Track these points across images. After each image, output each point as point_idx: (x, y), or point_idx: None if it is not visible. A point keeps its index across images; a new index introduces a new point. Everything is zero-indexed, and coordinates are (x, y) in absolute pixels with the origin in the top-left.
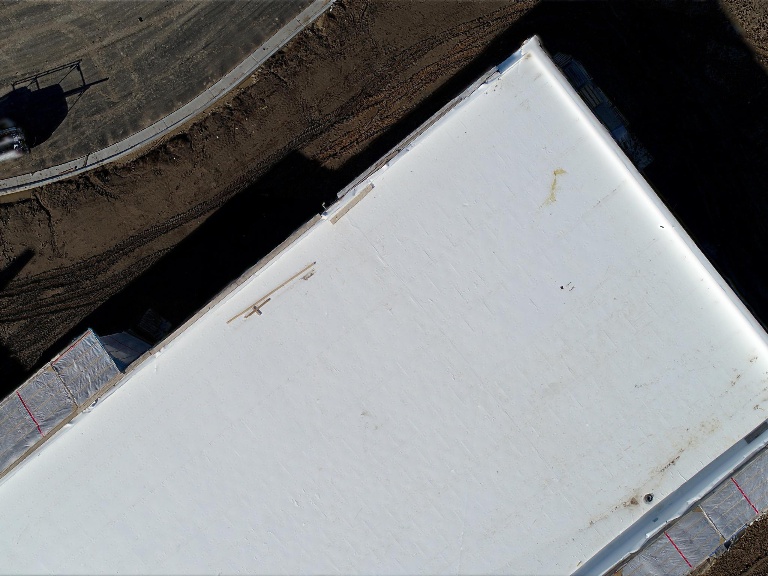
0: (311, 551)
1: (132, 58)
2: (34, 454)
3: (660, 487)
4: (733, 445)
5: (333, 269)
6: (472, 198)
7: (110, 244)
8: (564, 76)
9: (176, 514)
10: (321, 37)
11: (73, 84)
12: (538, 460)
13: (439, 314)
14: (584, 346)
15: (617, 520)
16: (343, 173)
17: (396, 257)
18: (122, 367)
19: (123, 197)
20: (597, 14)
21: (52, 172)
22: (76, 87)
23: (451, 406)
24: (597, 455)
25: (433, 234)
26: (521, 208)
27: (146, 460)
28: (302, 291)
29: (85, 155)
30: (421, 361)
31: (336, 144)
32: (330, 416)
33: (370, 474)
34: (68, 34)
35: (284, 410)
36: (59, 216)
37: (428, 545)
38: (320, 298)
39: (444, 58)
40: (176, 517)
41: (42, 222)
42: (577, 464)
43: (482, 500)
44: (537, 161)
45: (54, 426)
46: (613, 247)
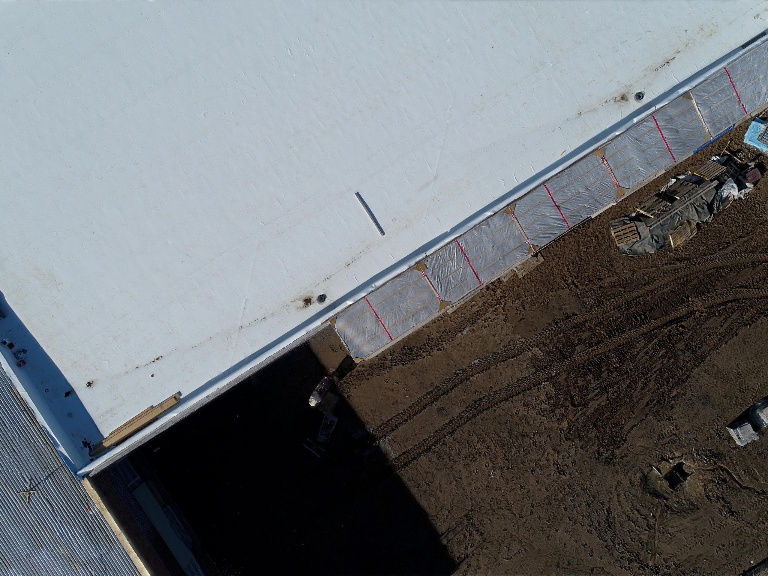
0: (298, 103)
1: None
2: None
3: (652, 86)
4: (729, 52)
5: None
6: None
7: None
8: None
9: (169, 46)
10: None
11: None
12: (534, 41)
13: None
14: None
15: (606, 114)
16: None
17: None
18: None
19: None
20: None
21: None
22: None
23: None
24: (593, 45)
25: None
26: None
27: None
28: None
29: None
30: None
31: None
32: None
33: (366, 32)
34: None
35: None
36: None
37: (415, 113)
38: None
39: None
40: (169, 49)
41: None
42: (572, 51)
43: (474, 74)
44: None
45: None
46: None
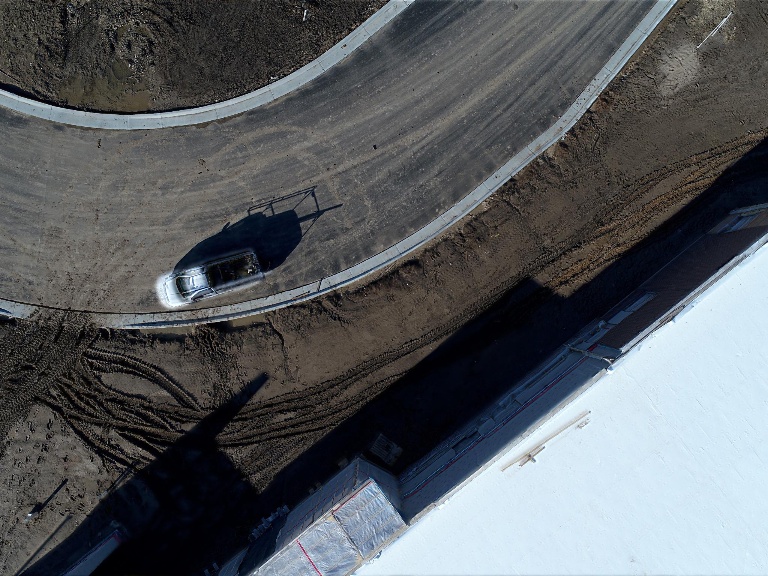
0: None
1: (366, 185)
2: None
3: None
4: None
5: (607, 418)
6: (745, 348)
7: (343, 369)
8: None
9: None
10: (553, 166)
11: (307, 210)
12: None
13: (710, 462)
14: None
15: None
16: (574, 300)
17: (669, 406)
18: (407, 519)
19: (356, 322)
20: None
21: (285, 296)
22: (310, 213)
23: (720, 554)
24: None
25: (706, 384)
26: None
27: None
28: (576, 439)
29: (318, 280)
30: (691, 509)
31: (568, 272)
32: (600, 563)
33: None
34: (303, 161)
35: (555, 557)
36: (293, 341)
37: None
38: (594, 446)
39: (676, 188)
40: None
41: (276, 346)
42: None
43: None
44: None
45: None
46: None
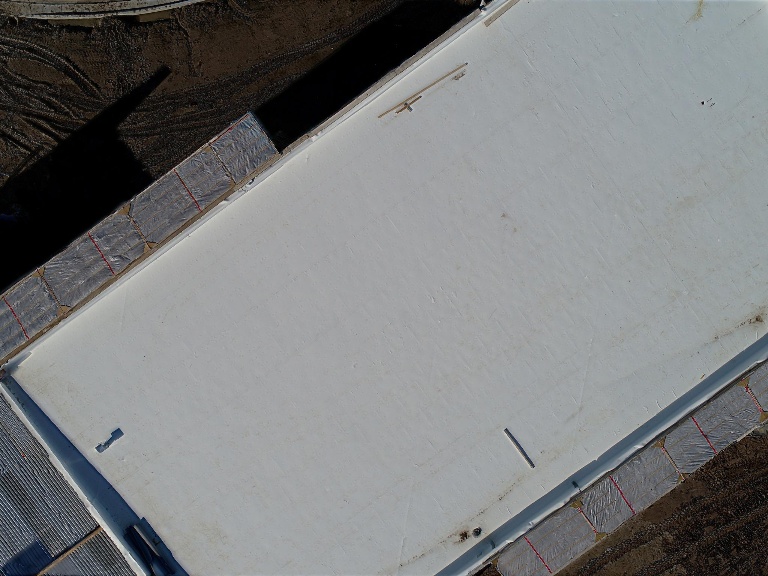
0: (444, 348)
1: None
2: (190, 228)
3: None
4: None
5: (484, 71)
6: (622, 9)
7: (245, 66)
8: None
9: (317, 303)
10: None
11: None
12: (669, 272)
13: (583, 122)
14: (721, 162)
15: (742, 336)
16: (475, 8)
17: (545, 63)
18: (280, 148)
19: (260, 21)
20: None
21: None
22: None
23: (589, 213)
24: (726, 271)
25: (582, 42)
26: (668, 22)
27: (292, 248)
28: (452, 91)
29: None
30: (562, 167)
31: None
32: (471, 216)
33: (506, 276)
34: None
35: (427, 207)
36: (197, 36)
37: (558, 349)
38: (469, 99)
39: None
40: (317, 306)
41: (180, 41)
42: (707, 278)
43: (613, 308)
44: None
45: (212, 201)
46: (755, 66)
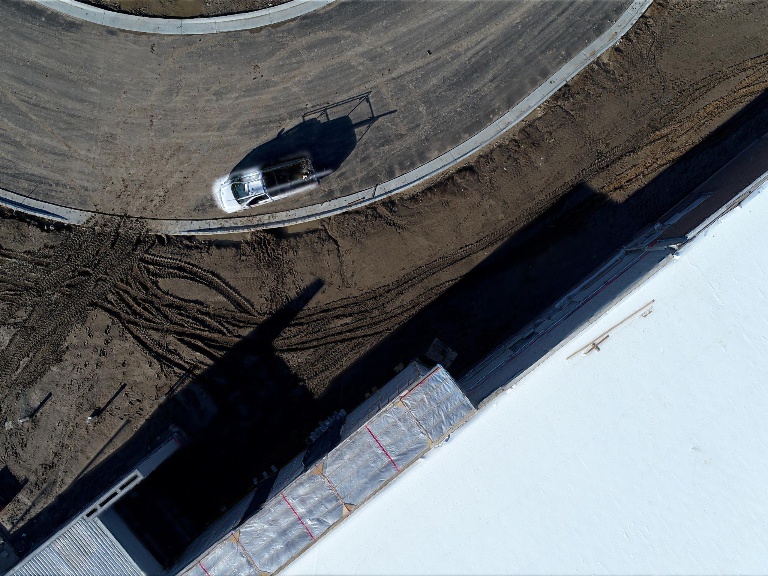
0: None
1: (420, 90)
2: (387, 488)
3: None
4: None
5: (670, 307)
6: None
7: (398, 274)
8: None
9: (509, 545)
10: (608, 71)
11: (362, 116)
12: None
13: None
14: None
15: None
16: (628, 206)
17: (732, 295)
18: (475, 403)
19: (411, 228)
20: None
21: (341, 203)
22: (365, 119)
23: None
24: None
25: None
26: None
27: (483, 493)
28: (640, 328)
29: (373, 186)
30: (751, 397)
31: (622, 177)
32: (661, 450)
33: (698, 507)
34: (358, 66)
35: (617, 444)
36: (348, 246)
37: None
38: (657, 335)
39: (730, 93)
40: (509, 548)
41: (331, 252)
42: None
43: None
44: None
45: (409, 461)
46: None
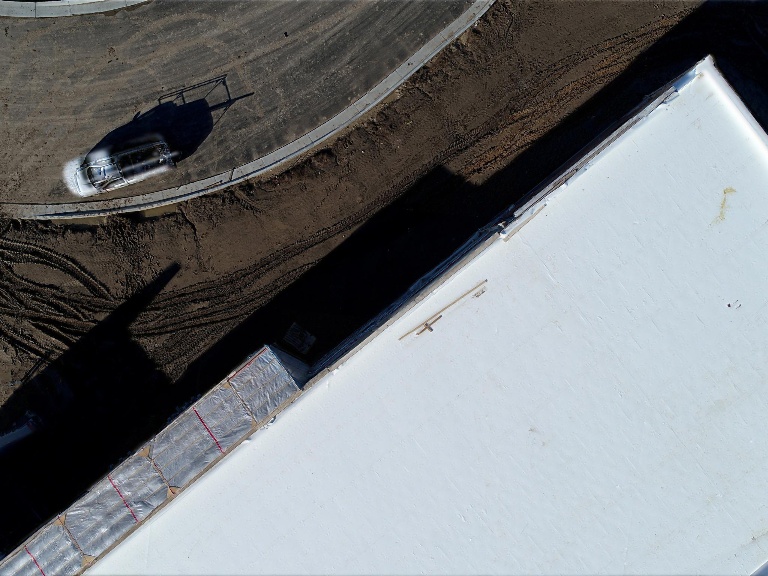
0: (477, 566)
1: (277, 73)
2: (213, 470)
3: None
4: None
5: (504, 286)
6: (642, 216)
7: (256, 258)
8: (737, 96)
9: (345, 529)
10: (466, 52)
11: (219, 99)
12: (702, 476)
13: (607, 331)
14: (750, 363)
15: None
16: (487, 188)
17: (566, 275)
18: (300, 384)
19: (268, 211)
20: (741, 30)
21: (197, 186)
22: (222, 102)
23: (618, 423)
24: (760, 471)
25: (603, 252)
26: (690, 226)
27: (316, 475)
28: (473, 308)
29: (230, 169)
30: (589, 378)
31: (481, 159)
32: (498, 432)
33: (536, 490)
34: (214, 49)
35: (453, 426)
36: (205, 230)
37: (592, 560)
38: (491, 315)
39: (589, 74)
40: (345, 532)
41: (188, 236)
42: (740, 480)
43: (646, 516)
44: (707, 180)
45: (234, 442)
46: None
